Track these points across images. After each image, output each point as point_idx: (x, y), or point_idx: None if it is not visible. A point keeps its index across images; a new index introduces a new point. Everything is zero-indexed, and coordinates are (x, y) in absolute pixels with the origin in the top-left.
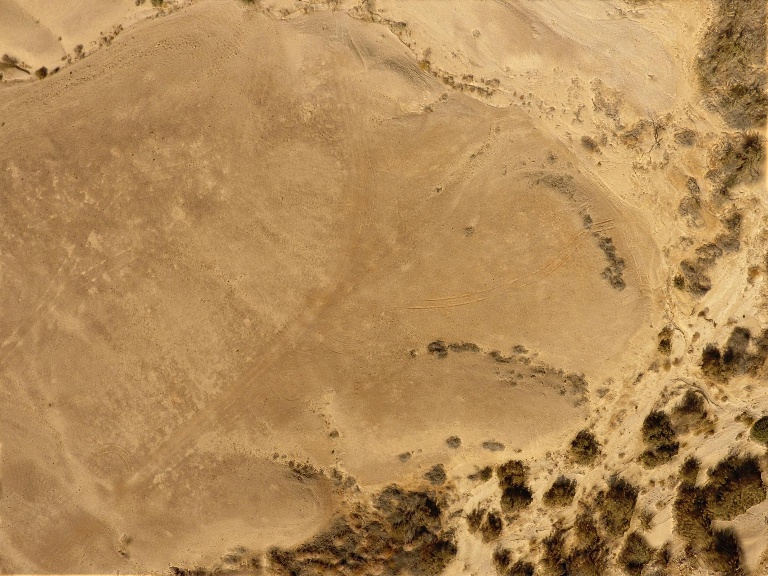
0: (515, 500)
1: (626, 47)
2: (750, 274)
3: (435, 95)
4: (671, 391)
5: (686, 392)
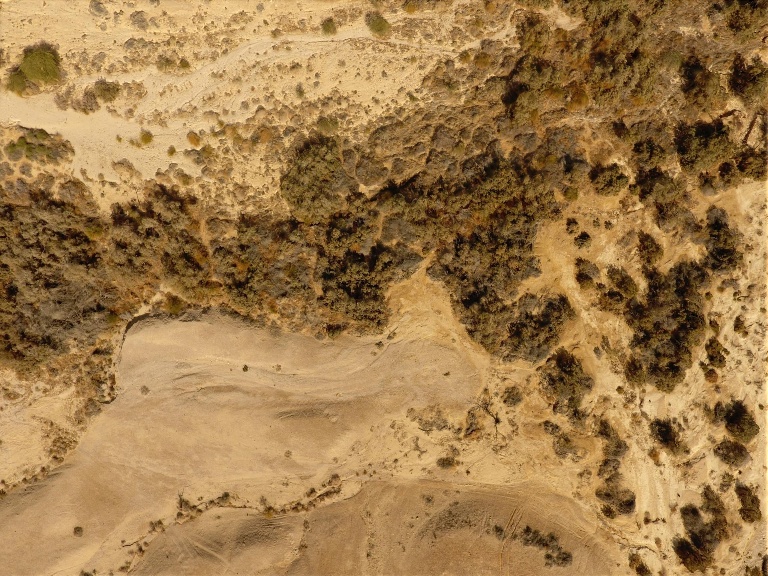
0: None
1: (409, 367)
2: (654, 459)
3: (298, 531)
4: None
5: None
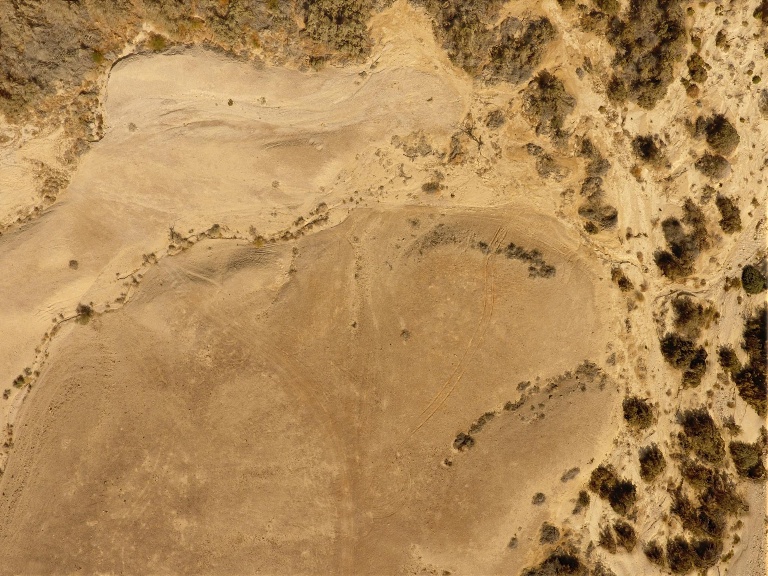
0: (623, 501)
1: (393, 95)
2: (636, 175)
3: (287, 257)
4: (660, 312)
5: (671, 303)
